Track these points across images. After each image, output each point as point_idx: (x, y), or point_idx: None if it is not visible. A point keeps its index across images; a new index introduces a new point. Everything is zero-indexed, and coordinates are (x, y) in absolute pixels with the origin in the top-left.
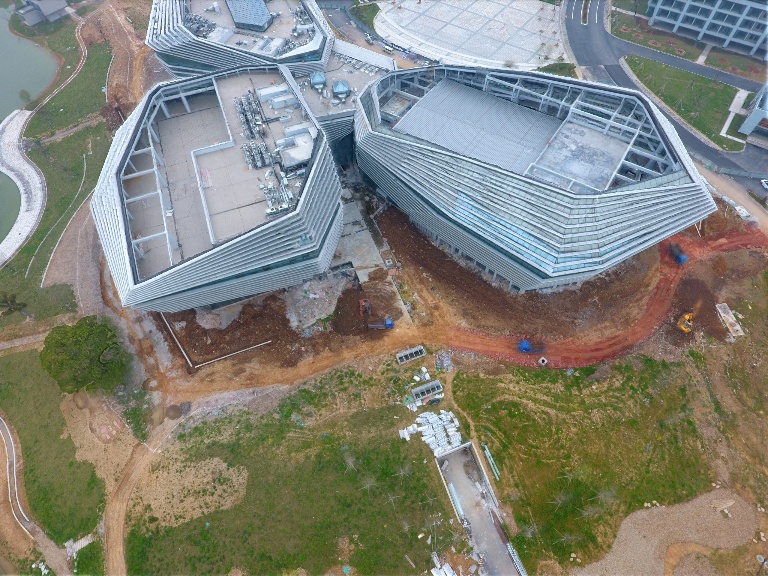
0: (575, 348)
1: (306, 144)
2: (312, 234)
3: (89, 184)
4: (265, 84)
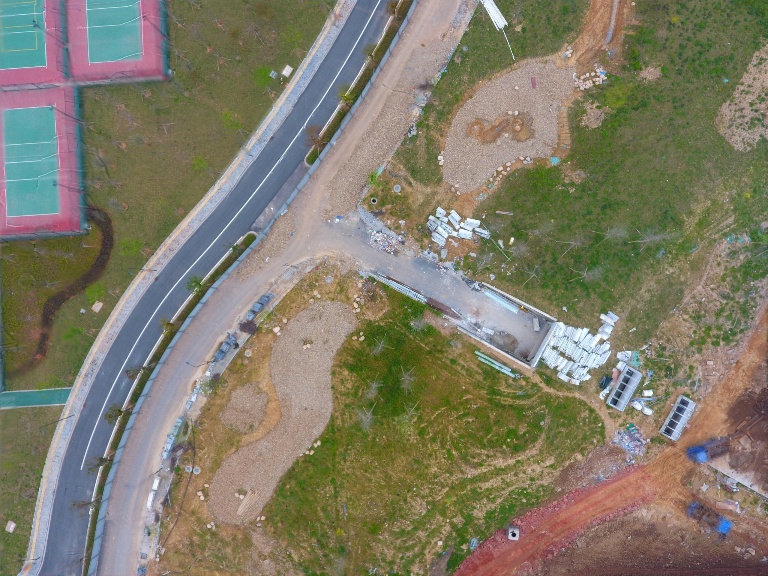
0: None
1: None
2: None
3: None
4: None
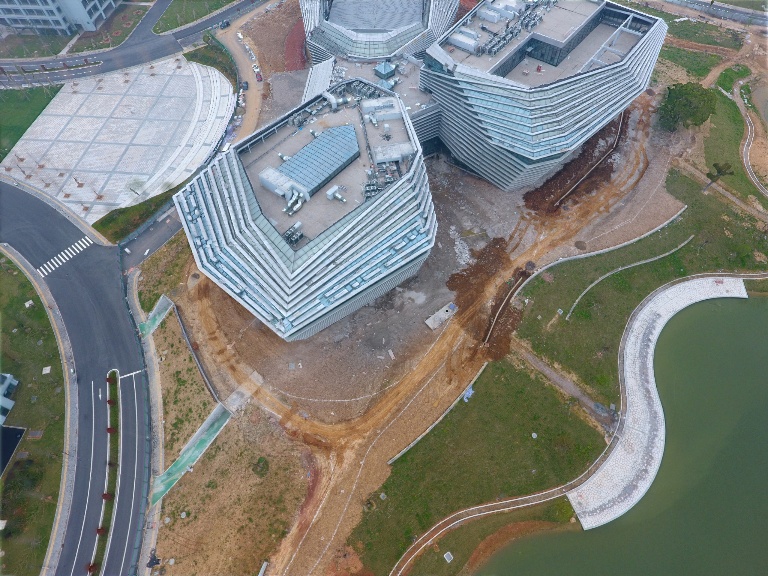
0: (462, 1)
1: (500, 3)
2: None
3: (590, 272)
4: (455, 56)
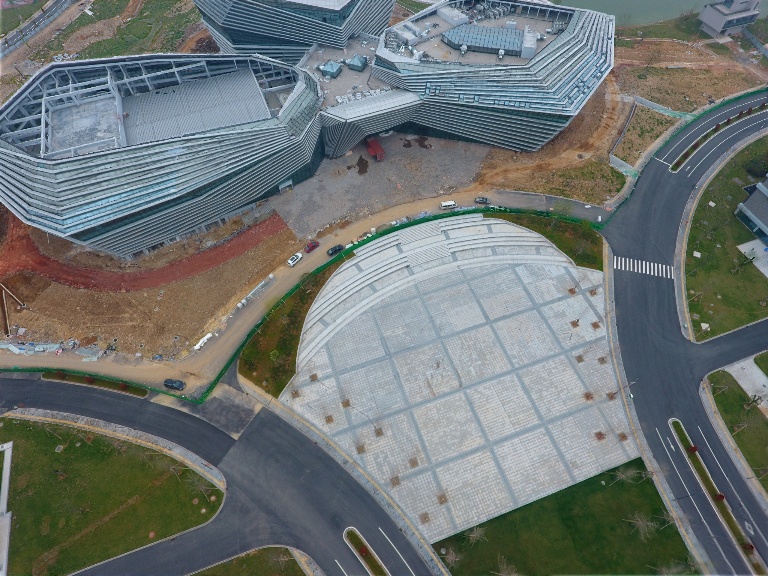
0: None
1: None
2: None
3: None
4: None
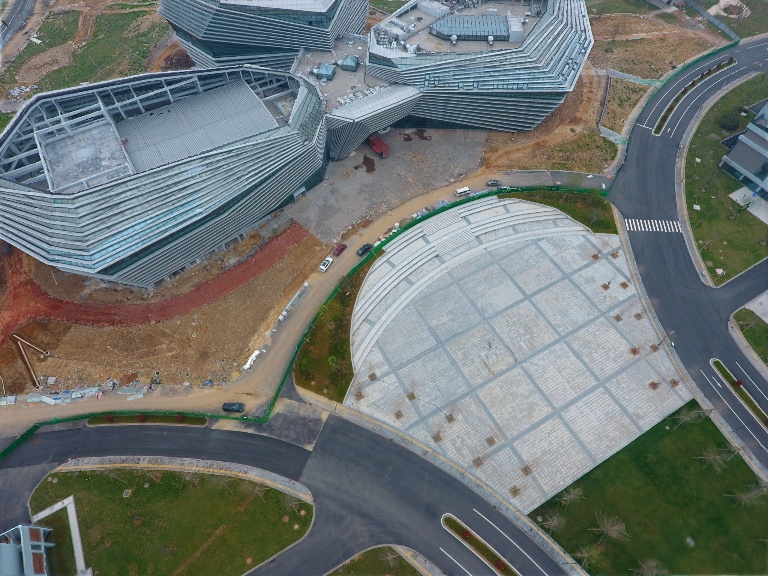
0: None
1: None
2: (162, 6)
3: (387, 9)
4: None
